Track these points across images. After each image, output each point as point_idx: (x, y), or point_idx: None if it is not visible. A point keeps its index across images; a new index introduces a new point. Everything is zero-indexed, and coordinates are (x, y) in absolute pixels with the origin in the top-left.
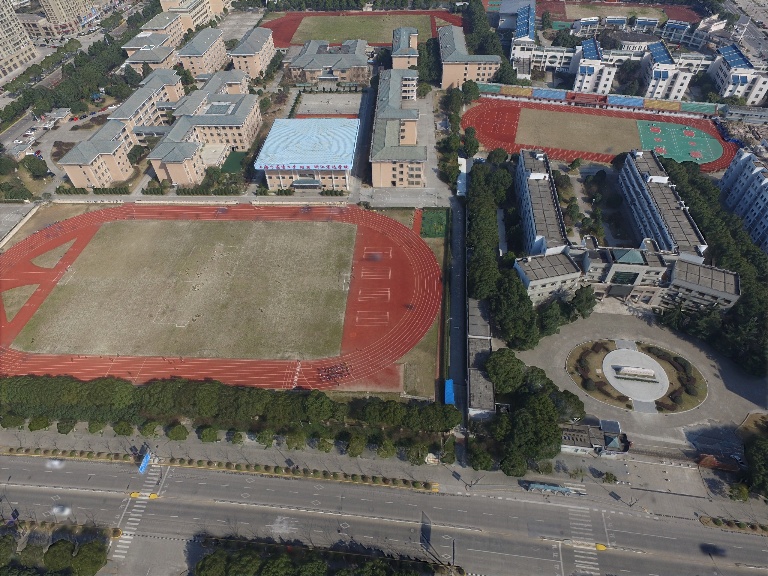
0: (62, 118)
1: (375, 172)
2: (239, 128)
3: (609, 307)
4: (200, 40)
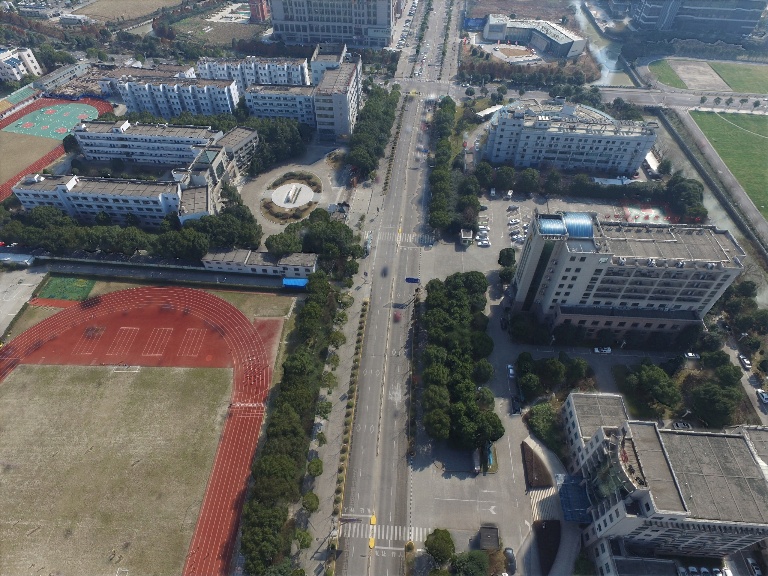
0: None
1: None
2: None
3: None
4: None
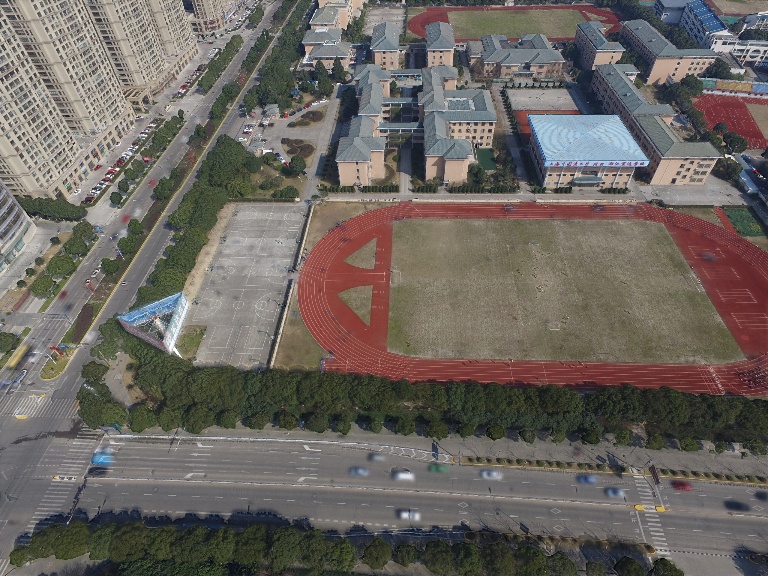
0: (275, 115)
1: (660, 169)
2: (492, 124)
3: None
4: (389, 35)
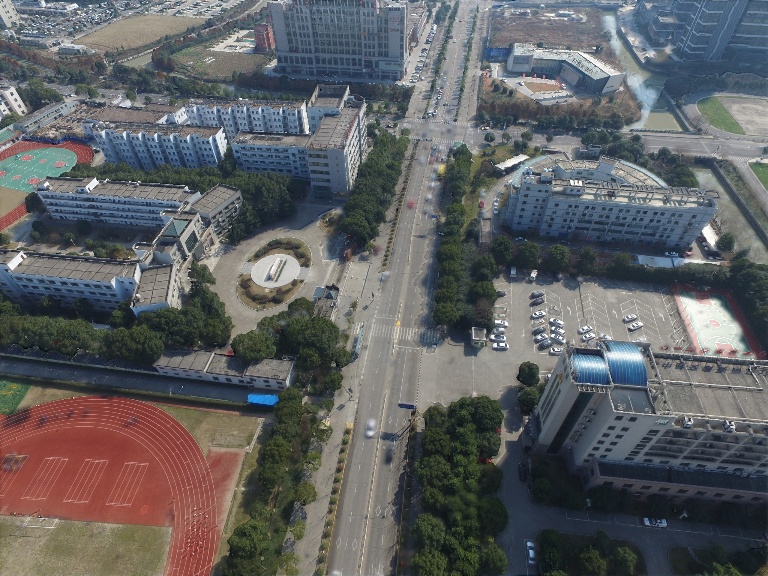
0: None
1: None
2: None
3: None
4: None
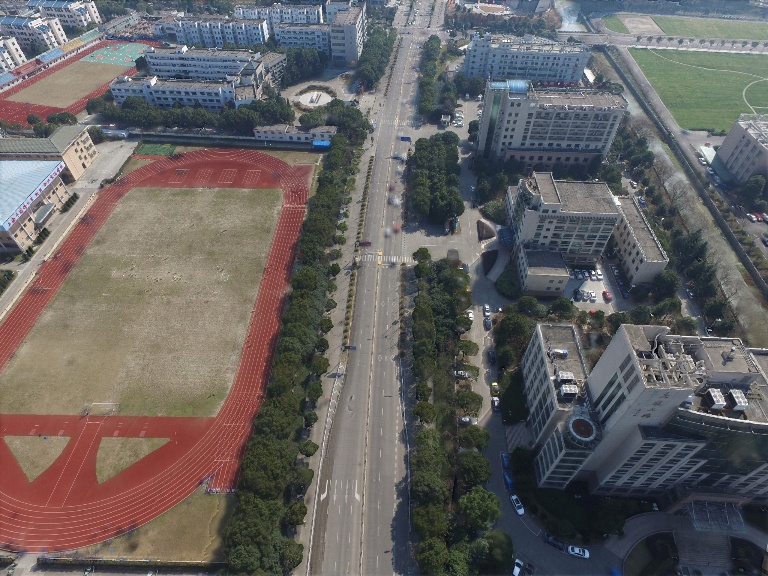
0: None
1: (69, 164)
2: None
3: None
4: None
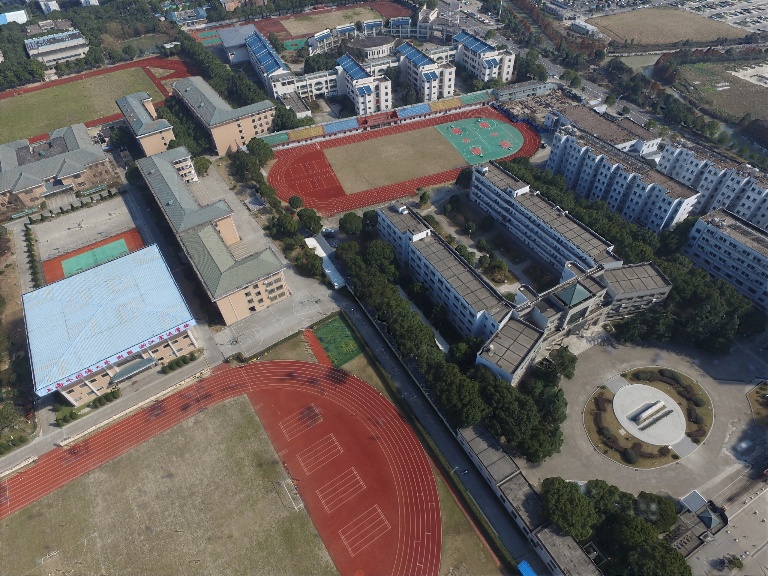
0: None
1: (224, 309)
2: None
3: (572, 348)
4: None
